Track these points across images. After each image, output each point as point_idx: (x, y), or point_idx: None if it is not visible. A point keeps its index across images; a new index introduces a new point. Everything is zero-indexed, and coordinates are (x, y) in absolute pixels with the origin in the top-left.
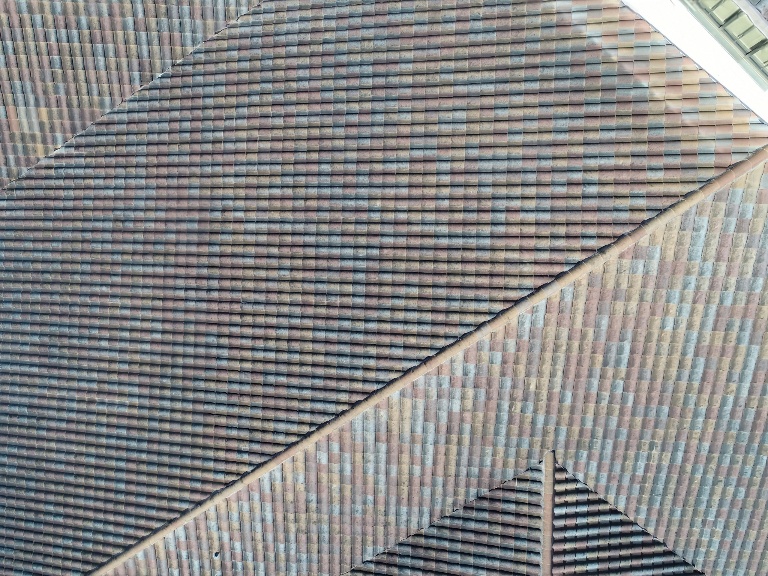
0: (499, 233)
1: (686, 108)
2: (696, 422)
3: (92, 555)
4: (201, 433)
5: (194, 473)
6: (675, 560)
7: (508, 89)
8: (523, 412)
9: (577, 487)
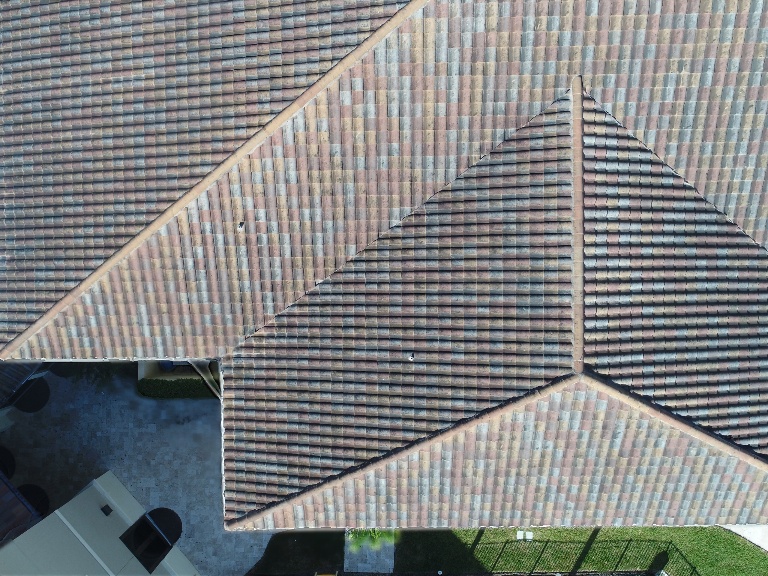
0: None
1: None
2: (725, 33)
3: (114, 238)
4: (220, 92)
5: (215, 133)
6: (707, 208)
7: None
8: (549, 30)
9: (606, 121)
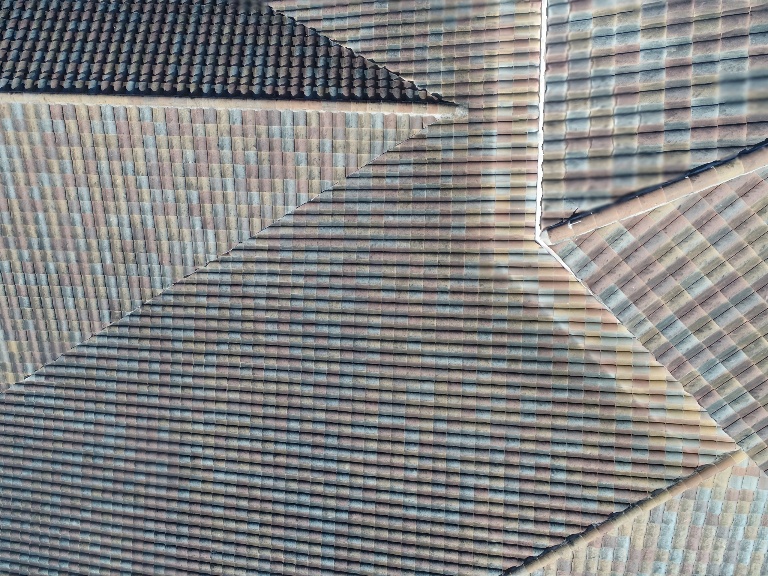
0: (468, 509)
1: (653, 404)
2: None
3: None
4: None
5: None
6: None
7: (476, 365)
8: None
9: None
